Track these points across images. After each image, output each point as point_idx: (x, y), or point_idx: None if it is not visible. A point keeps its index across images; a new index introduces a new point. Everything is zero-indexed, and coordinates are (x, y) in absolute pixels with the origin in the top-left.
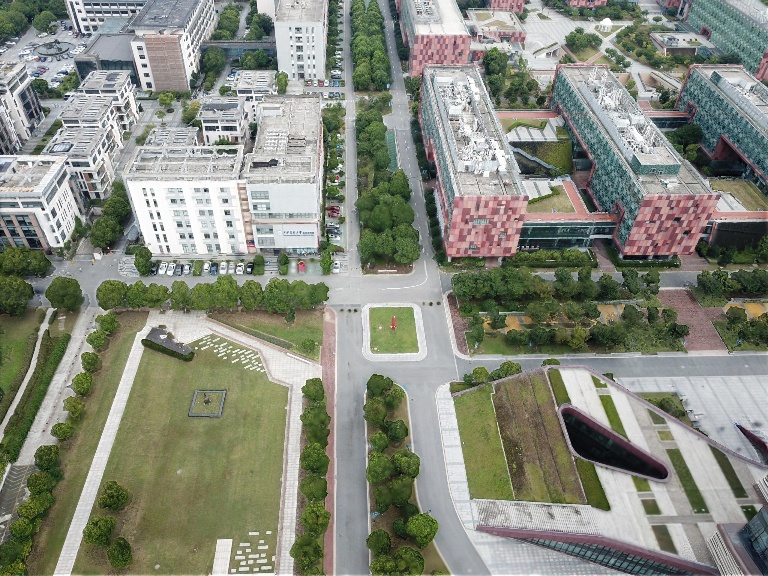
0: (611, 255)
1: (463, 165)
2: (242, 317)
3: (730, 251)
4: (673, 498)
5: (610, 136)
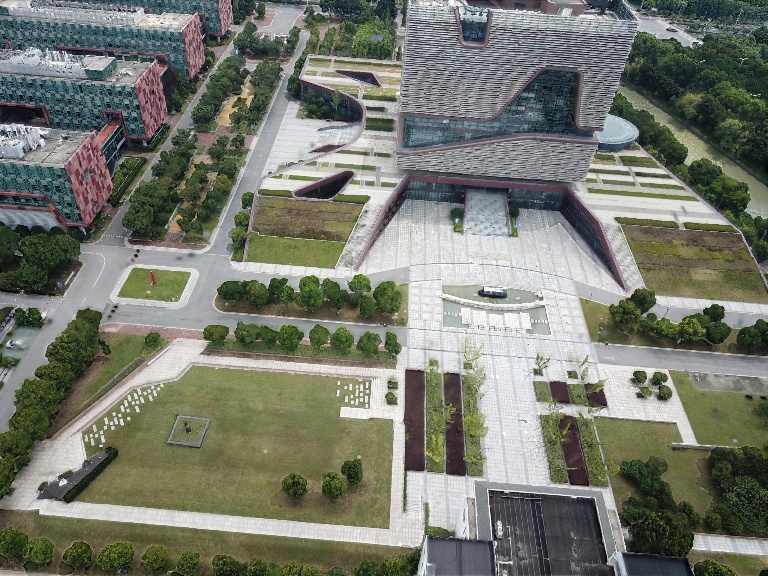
0: (139, 149)
1: (20, 149)
2: (70, 403)
3: (174, 100)
4: (366, 175)
5: (38, 75)
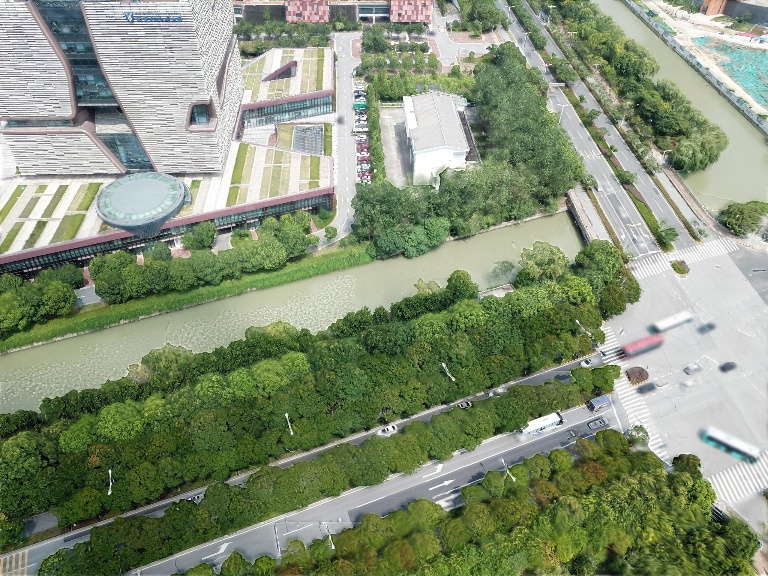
0: None
1: None
2: None
3: (251, 22)
4: None
5: None
